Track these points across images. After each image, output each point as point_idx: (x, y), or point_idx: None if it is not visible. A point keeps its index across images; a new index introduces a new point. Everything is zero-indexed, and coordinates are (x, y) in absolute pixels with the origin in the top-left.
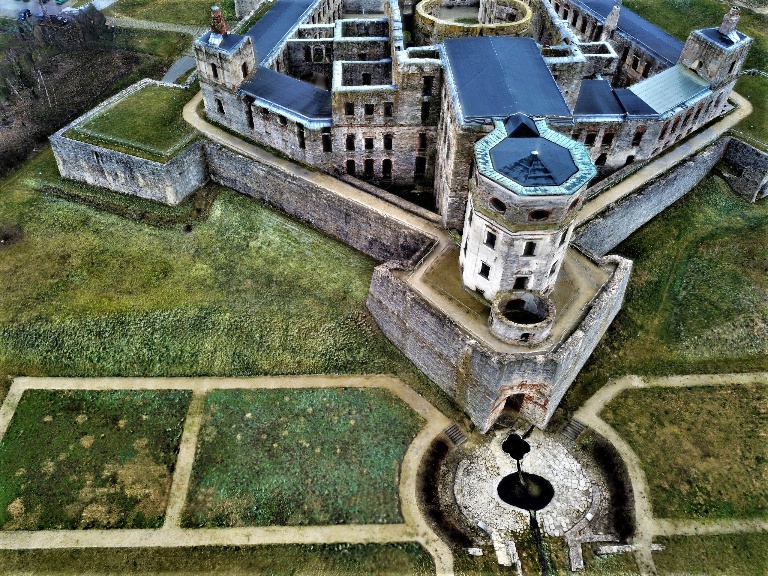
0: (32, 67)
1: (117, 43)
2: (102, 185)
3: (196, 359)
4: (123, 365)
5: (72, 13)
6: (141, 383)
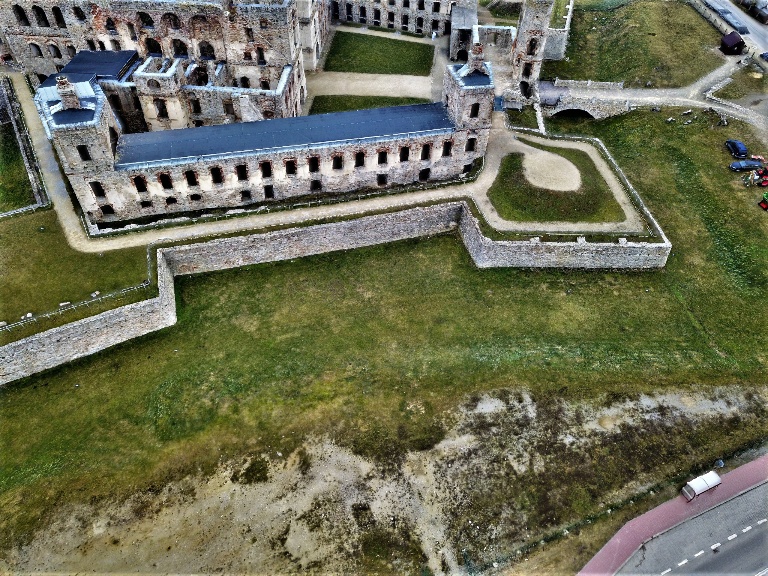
0: None
1: None
2: None
3: None
4: None
5: None
6: None
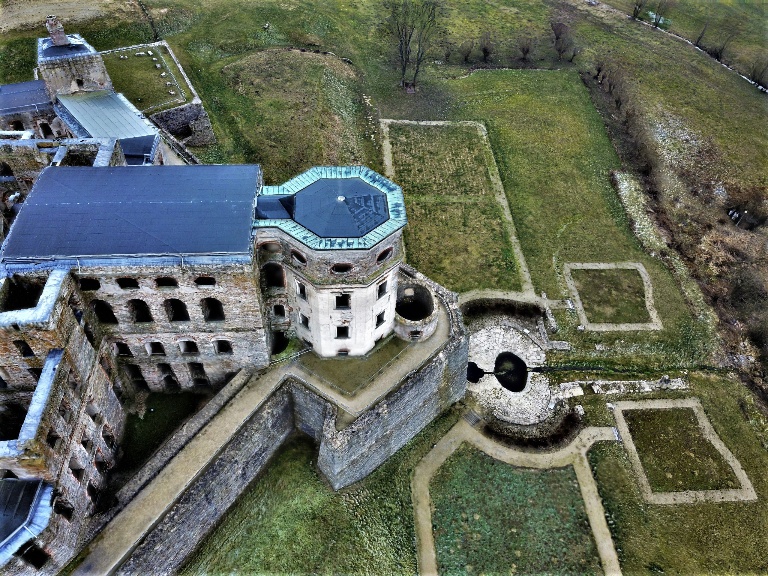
0: None
1: None
2: None
3: None
4: None
5: None
6: None
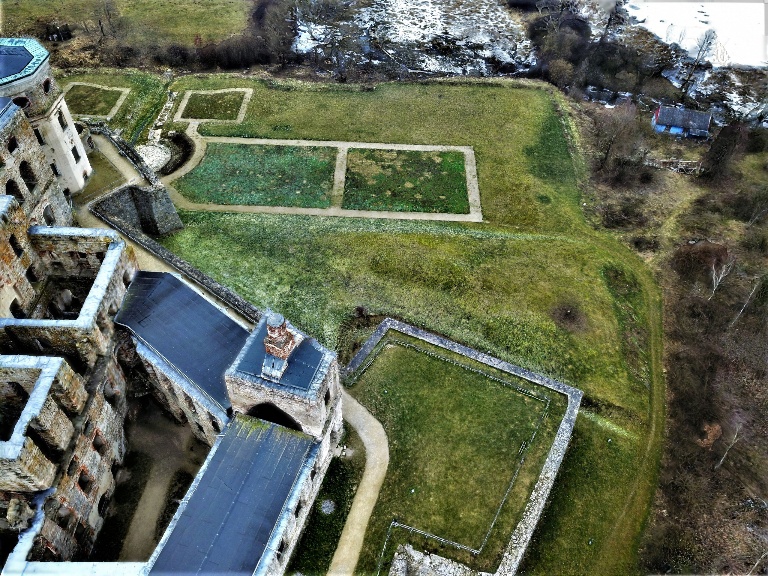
0: None
1: None
2: None
3: None
4: (400, 222)
5: None
6: (383, 215)
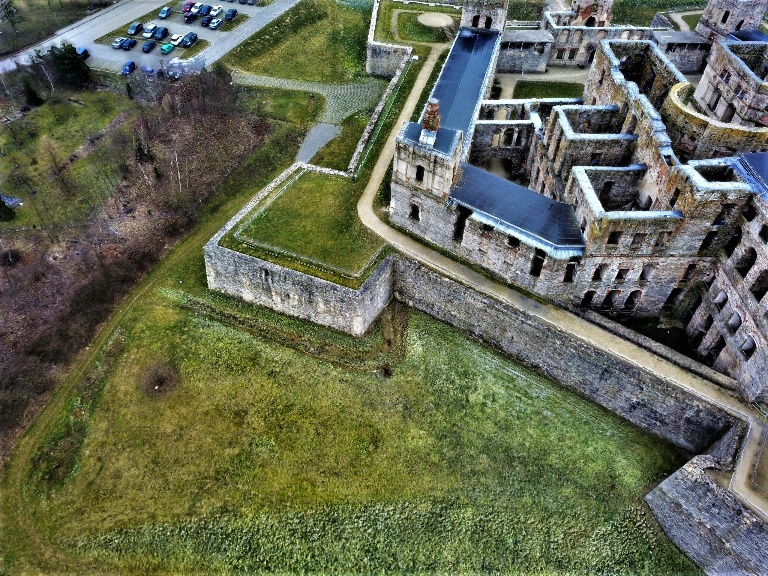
0: (147, 135)
1: (238, 104)
2: (264, 304)
3: (433, 573)
4: None
5: (182, 66)
6: None
